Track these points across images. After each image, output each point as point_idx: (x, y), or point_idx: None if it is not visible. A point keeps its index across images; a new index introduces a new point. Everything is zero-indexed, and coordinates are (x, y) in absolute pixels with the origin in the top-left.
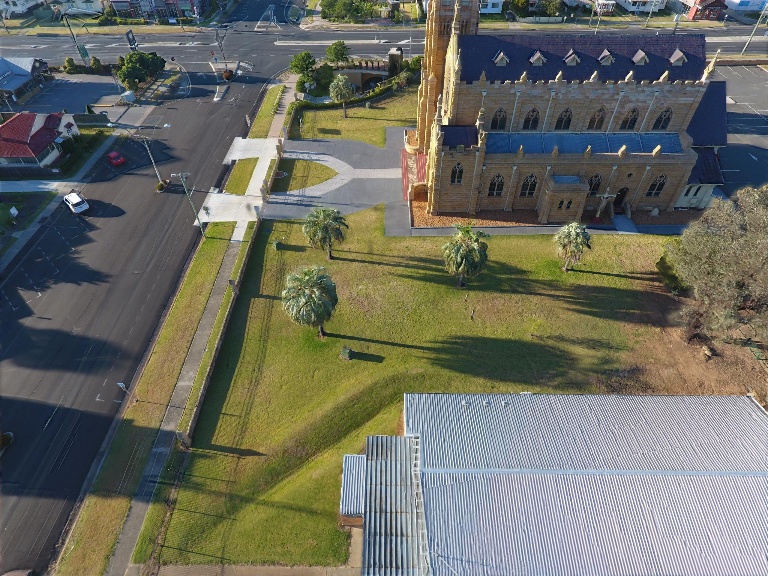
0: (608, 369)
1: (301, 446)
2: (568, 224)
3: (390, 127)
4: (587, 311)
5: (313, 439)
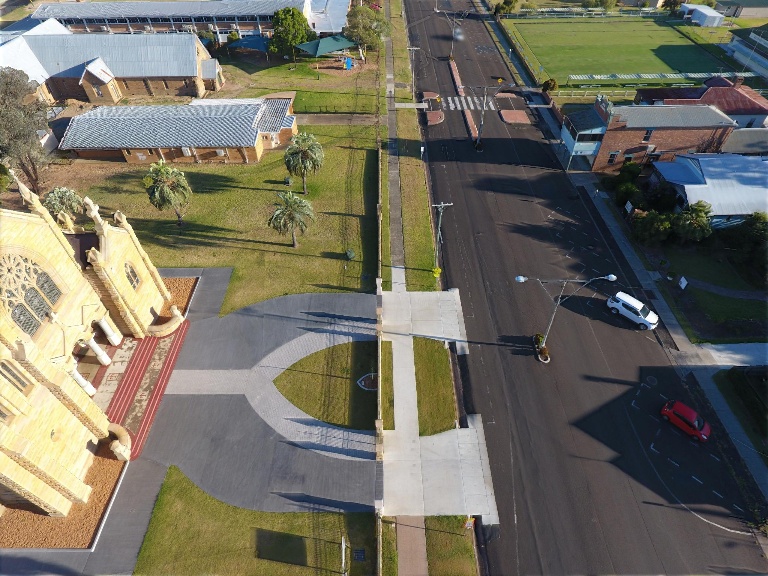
0: (119, 176)
1: None
2: None
3: (121, 569)
4: None
5: None
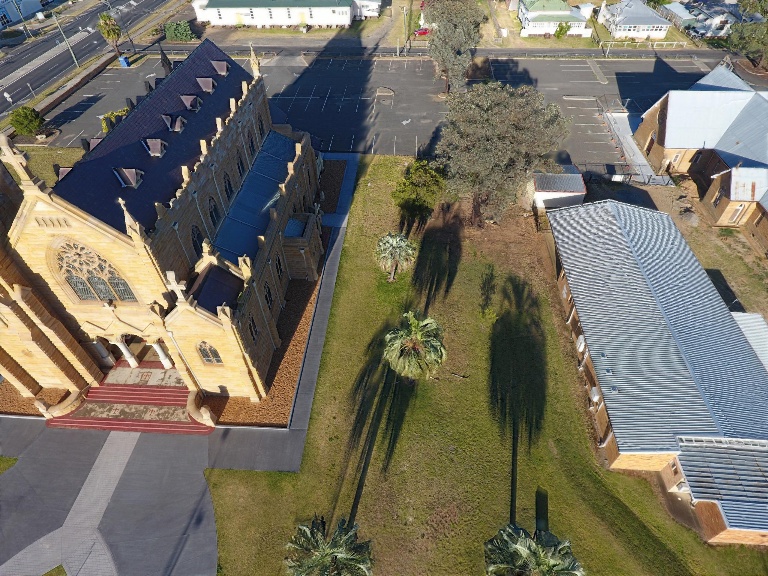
0: (519, 282)
1: None
2: (323, 259)
3: None
4: (449, 278)
5: None
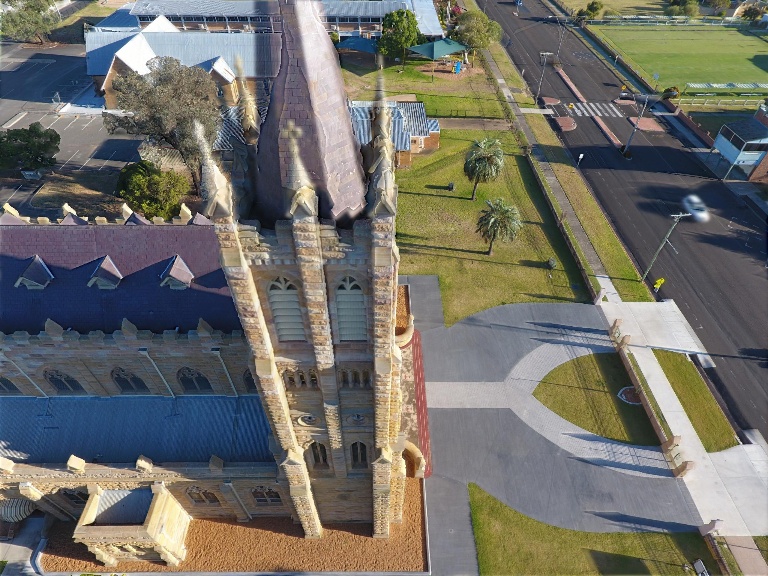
0: None
1: (465, 154)
2: None
3: None
4: None
5: (459, 156)
